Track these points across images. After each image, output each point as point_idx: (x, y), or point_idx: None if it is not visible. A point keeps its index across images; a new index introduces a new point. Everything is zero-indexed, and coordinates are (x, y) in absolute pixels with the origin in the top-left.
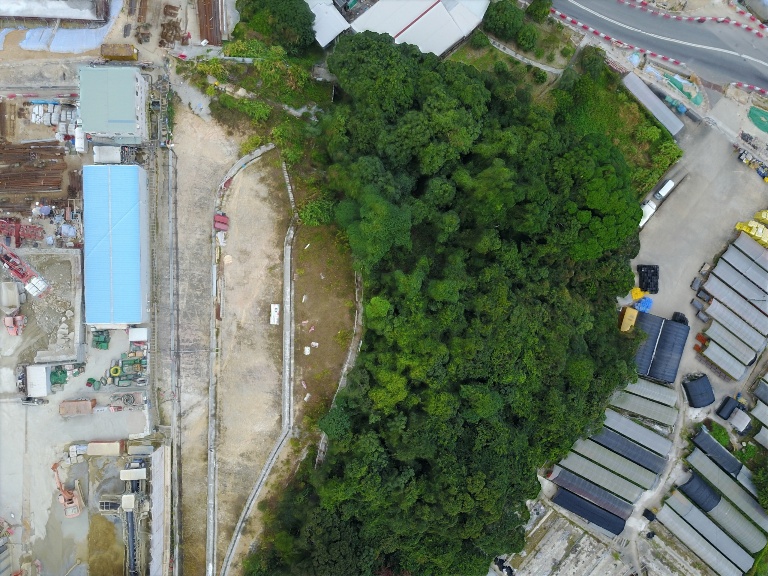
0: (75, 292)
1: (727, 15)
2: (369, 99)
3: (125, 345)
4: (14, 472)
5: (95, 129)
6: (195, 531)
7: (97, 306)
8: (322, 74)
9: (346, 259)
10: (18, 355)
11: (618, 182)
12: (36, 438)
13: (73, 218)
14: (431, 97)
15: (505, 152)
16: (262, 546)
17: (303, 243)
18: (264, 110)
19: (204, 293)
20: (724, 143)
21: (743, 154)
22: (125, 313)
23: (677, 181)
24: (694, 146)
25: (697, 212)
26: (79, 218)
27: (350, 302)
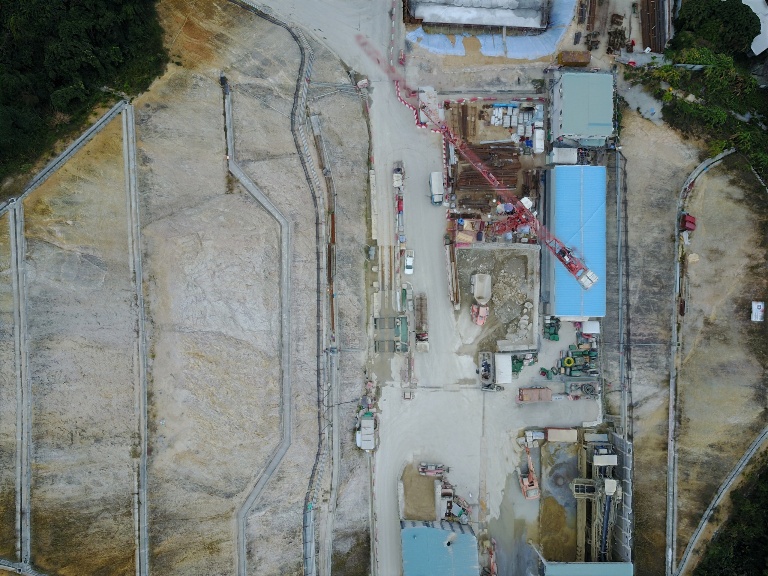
0: (532, 285)
1: None
2: None
3: (571, 337)
4: (472, 454)
5: (576, 131)
6: (651, 517)
7: (565, 299)
8: None
9: None
10: (478, 343)
11: None
12: (492, 423)
13: None
14: None
15: None
16: (733, 534)
17: None
18: (724, 115)
19: (663, 289)
20: None
21: None
22: (593, 306)
23: None
24: None
25: None
26: None
27: None
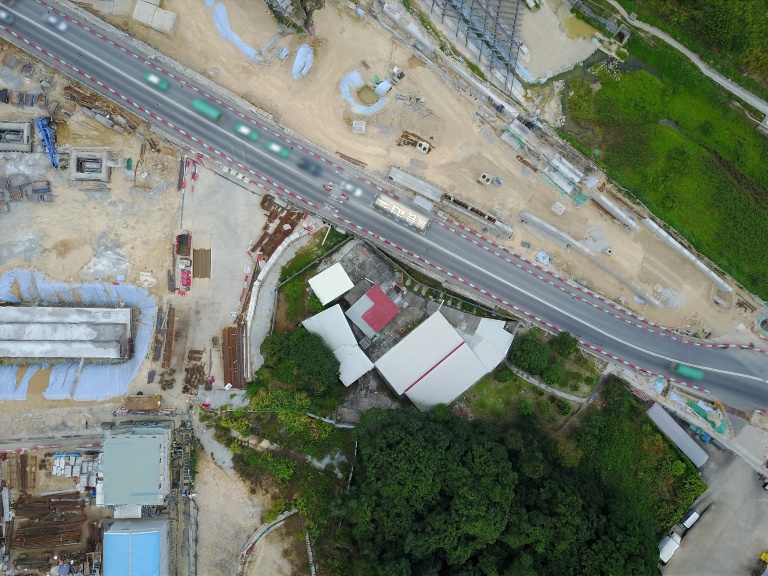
0: None
1: (750, 341)
2: (396, 502)
3: None
4: None
5: (117, 503)
6: None
7: None
8: (345, 414)
9: None
10: None
11: (647, 574)
12: None
13: (91, 573)
14: (459, 501)
15: (533, 547)
16: None
17: None
18: (288, 472)
19: None
20: (748, 471)
21: (767, 485)
22: None
23: (701, 509)
24: (718, 475)
25: (722, 543)
26: (97, 574)
27: None
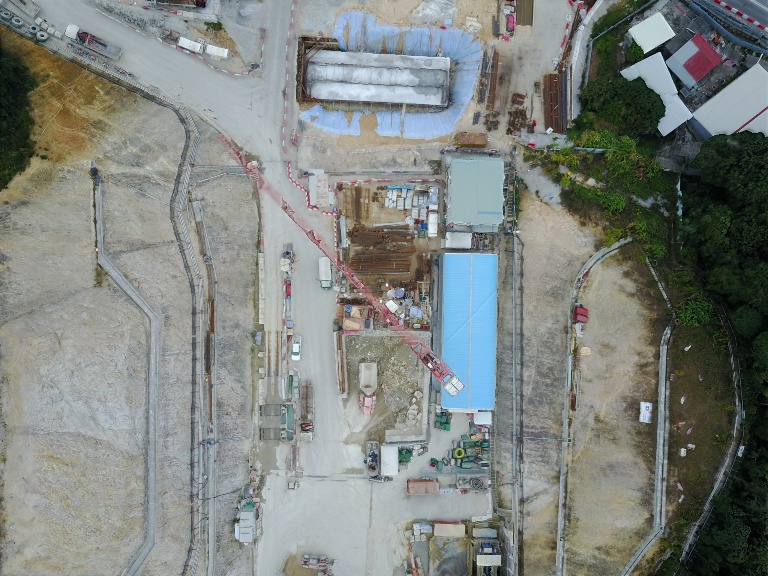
0: (423, 373)
1: None
2: (766, 205)
3: (464, 426)
4: (358, 546)
5: (464, 220)
6: None
7: None
8: (662, 163)
9: (722, 361)
10: (366, 432)
11: None
12: (380, 514)
13: (421, 300)
14: None
15: None
16: None
17: (682, 344)
18: (622, 203)
19: (555, 382)
20: None
21: None
22: (481, 399)
23: None
24: None
25: None
26: (428, 301)
27: (731, 406)
